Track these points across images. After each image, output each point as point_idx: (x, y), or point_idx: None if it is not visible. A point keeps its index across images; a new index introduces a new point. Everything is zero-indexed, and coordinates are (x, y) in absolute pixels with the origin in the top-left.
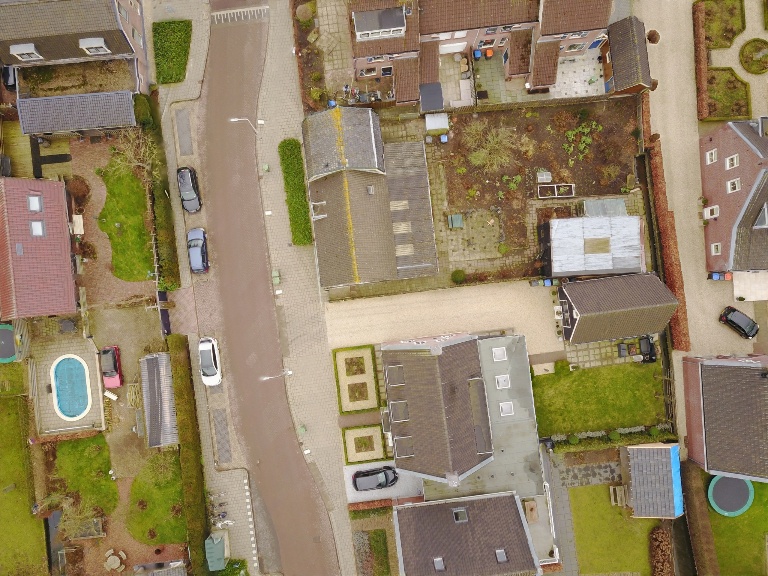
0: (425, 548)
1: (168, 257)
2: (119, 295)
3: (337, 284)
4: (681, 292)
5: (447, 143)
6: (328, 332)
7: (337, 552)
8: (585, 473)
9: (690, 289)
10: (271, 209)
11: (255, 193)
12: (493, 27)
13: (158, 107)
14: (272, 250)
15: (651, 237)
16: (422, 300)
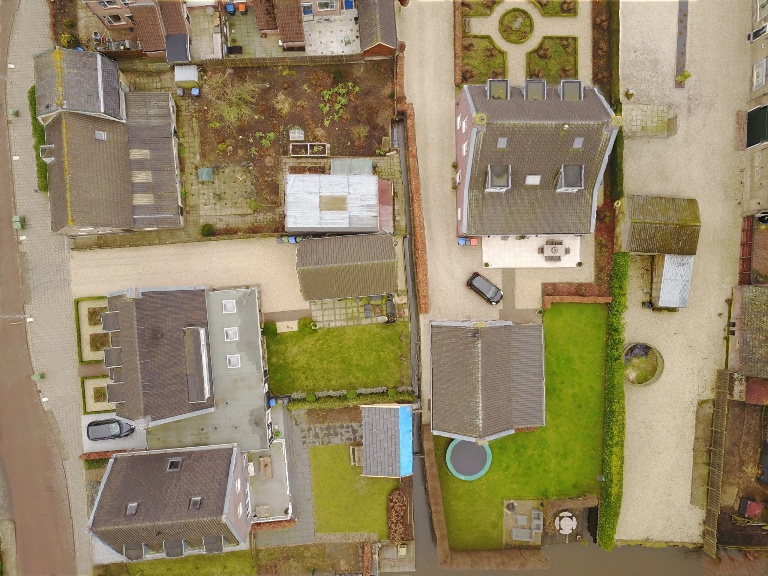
0: (124, 493)
1: None
2: None
3: (61, 228)
4: (424, 254)
5: (201, 97)
6: (73, 281)
7: (69, 502)
8: (327, 432)
9: (441, 254)
10: (19, 154)
11: (3, 137)
12: None
13: None
14: (18, 195)
15: (407, 201)
16: (170, 253)
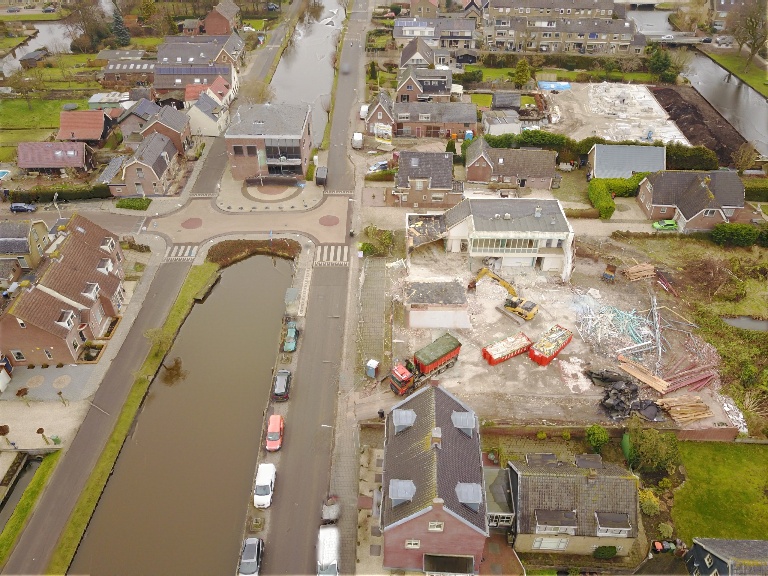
0: None
1: (23, 193)
2: (24, 187)
3: None
4: None
5: None
6: None
7: None
8: None
9: None
10: None
11: None
12: None
13: (105, 197)
14: None
15: None
16: None
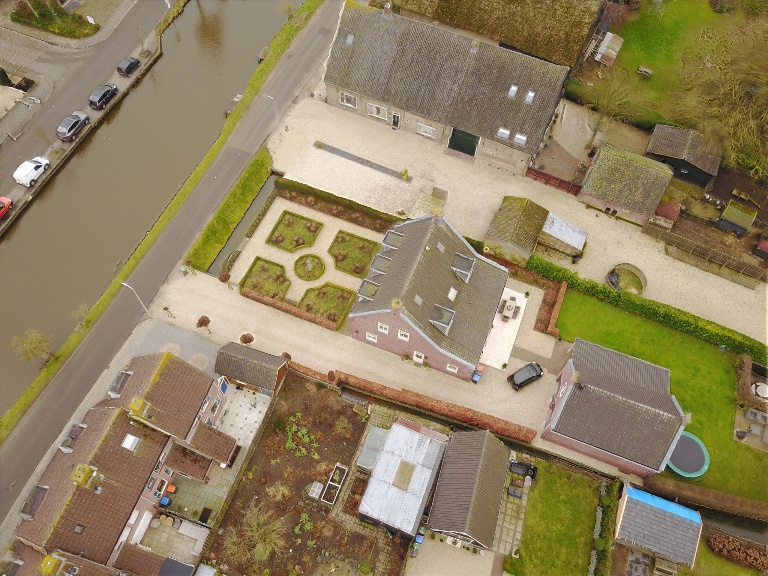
0: None
1: None
2: None
3: None
4: (479, 415)
5: None
6: None
7: None
8: None
9: (479, 403)
10: None
11: None
12: (148, 482)
13: None
14: None
15: (418, 414)
16: None
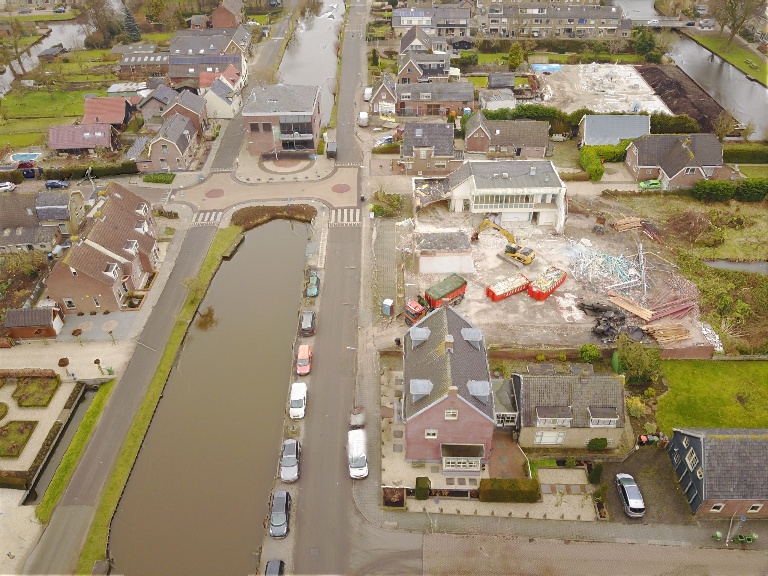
0: None
1: (56, 170)
2: None
3: None
4: None
5: None
6: None
7: None
8: None
9: None
10: None
11: None
12: None
13: None
14: None
15: None
16: None
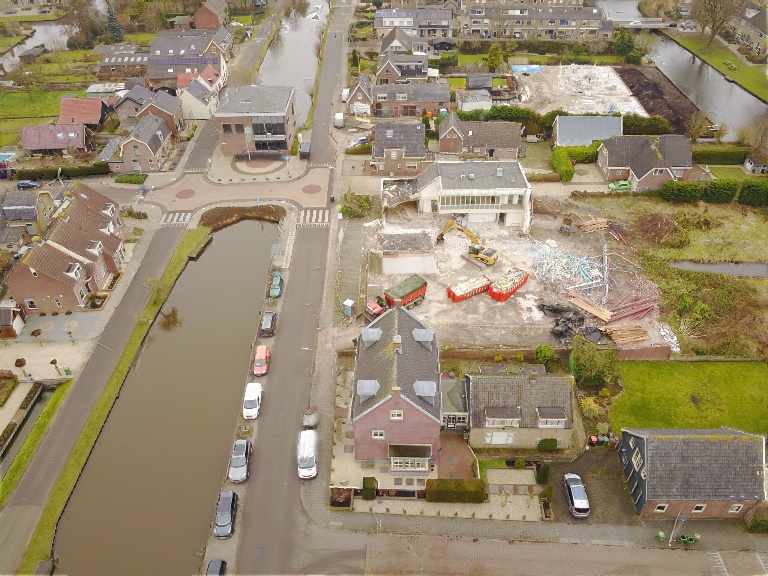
0: None
1: (28, 171)
2: (29, 167)
3: None
4: None
5: None
6: None
7: None
8: None
9: None
10: None
11: None
12: None
13: None
14: None
15: None
16: None
